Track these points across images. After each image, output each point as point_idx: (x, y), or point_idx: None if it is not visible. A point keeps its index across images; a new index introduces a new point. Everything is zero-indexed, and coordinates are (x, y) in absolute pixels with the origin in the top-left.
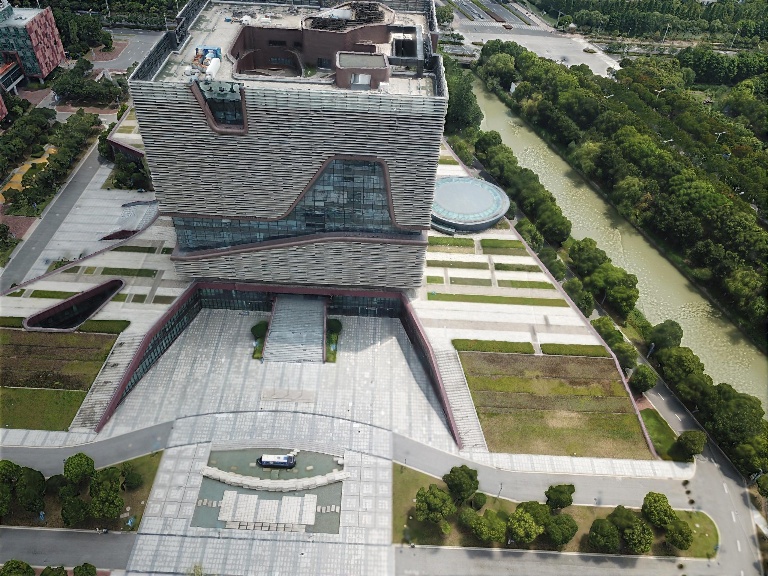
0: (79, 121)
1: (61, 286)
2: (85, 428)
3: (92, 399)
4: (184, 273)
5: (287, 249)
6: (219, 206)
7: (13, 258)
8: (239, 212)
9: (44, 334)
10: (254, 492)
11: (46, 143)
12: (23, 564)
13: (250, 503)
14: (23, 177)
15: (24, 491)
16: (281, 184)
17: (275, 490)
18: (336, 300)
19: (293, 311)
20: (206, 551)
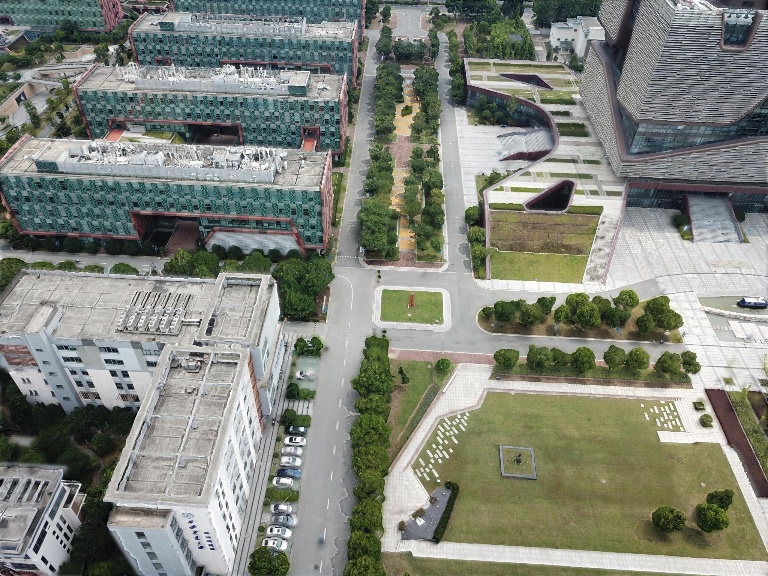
0: (425, 73)
1: (528, 184)
2: (594, 282)
3: (593, 261)
4: (626, 173)
5: (723, 150)
6: (688, 113)
7: (443, 173)
8: (701, 118)
9: (542, 215)
10: (750, 322)
11: (402, 91)
12: (645, 351)
13: (753, 328)
14: (417, 114)
15: (617, 307)
16: (748, 93)
17: (765, 321)
18: (734, 198)
19: (703, 206)
20: (743, 355)
